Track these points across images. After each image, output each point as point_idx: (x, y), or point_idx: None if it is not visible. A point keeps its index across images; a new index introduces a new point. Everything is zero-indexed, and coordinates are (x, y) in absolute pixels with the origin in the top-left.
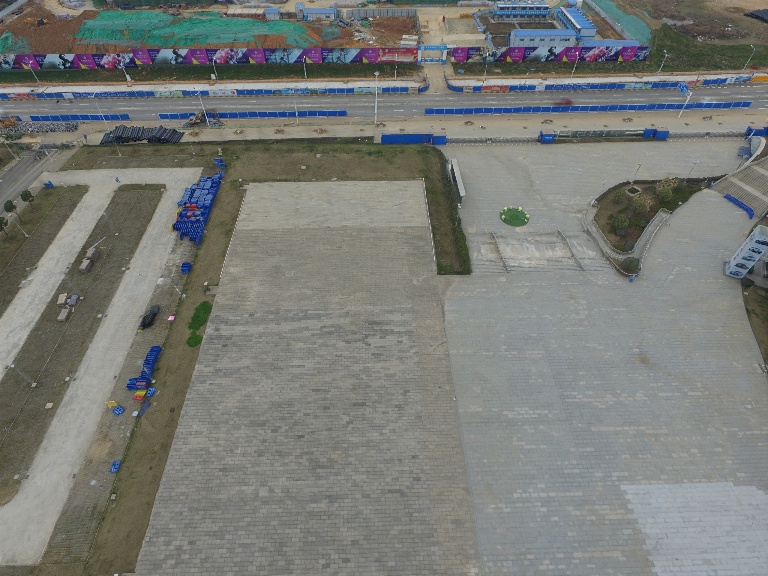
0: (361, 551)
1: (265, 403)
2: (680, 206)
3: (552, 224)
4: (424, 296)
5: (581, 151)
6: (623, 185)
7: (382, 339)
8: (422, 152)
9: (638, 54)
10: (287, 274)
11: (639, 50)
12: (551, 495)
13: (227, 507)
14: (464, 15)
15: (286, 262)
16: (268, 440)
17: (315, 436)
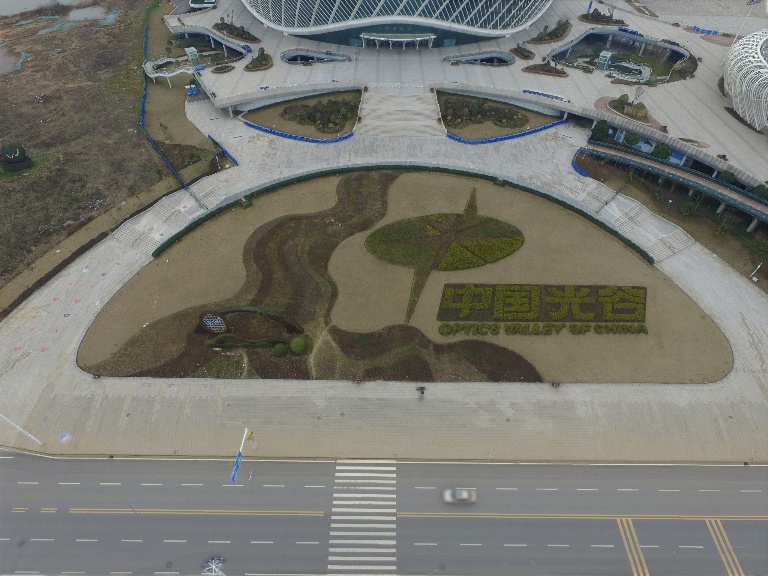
0: (653, 5)
1: None
2: None
3: None
4: (752, 14)
5: None
6: None
7: (722, 8)
8: None
9: None
10: None
11: None
12: (689, 22)
13: None
14: None
15: None
16: None
17: None
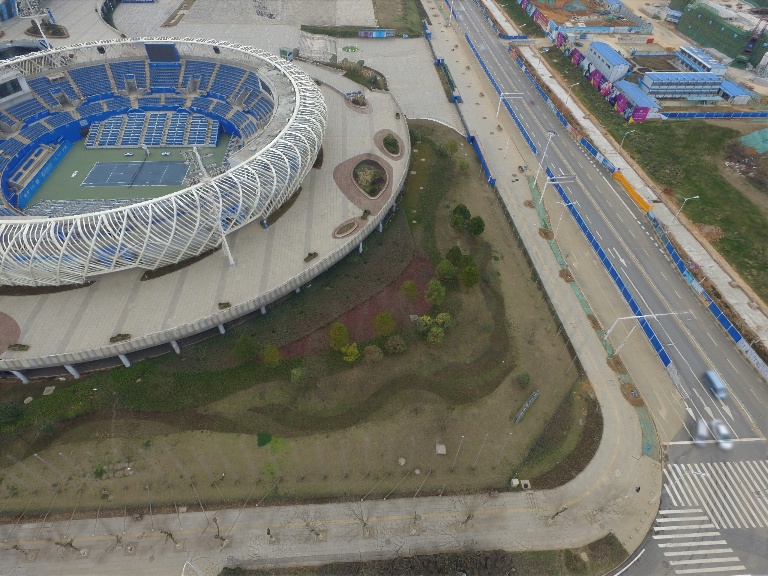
0: None
1: (248, 3)
2: (351, 80)
3: (344, 56)
4: (289, 22)
5: (426, 73)
6: (381, 75)
7: None
8: (409, 29)
9: (626, 110)
10: (307, 4)
11: (627, 105)
12: None
13: (216, 1)
14: (670, 48)
15: (314, 4)
16: (234, 4)
17: (233, 8)
